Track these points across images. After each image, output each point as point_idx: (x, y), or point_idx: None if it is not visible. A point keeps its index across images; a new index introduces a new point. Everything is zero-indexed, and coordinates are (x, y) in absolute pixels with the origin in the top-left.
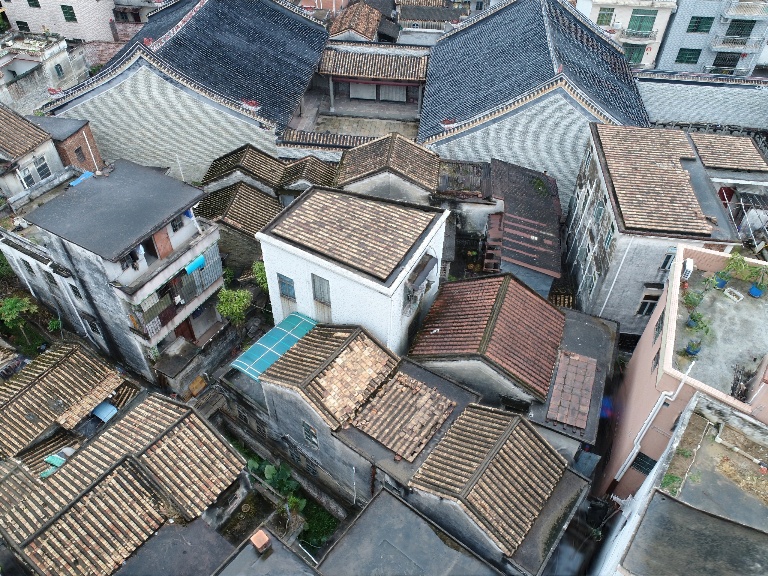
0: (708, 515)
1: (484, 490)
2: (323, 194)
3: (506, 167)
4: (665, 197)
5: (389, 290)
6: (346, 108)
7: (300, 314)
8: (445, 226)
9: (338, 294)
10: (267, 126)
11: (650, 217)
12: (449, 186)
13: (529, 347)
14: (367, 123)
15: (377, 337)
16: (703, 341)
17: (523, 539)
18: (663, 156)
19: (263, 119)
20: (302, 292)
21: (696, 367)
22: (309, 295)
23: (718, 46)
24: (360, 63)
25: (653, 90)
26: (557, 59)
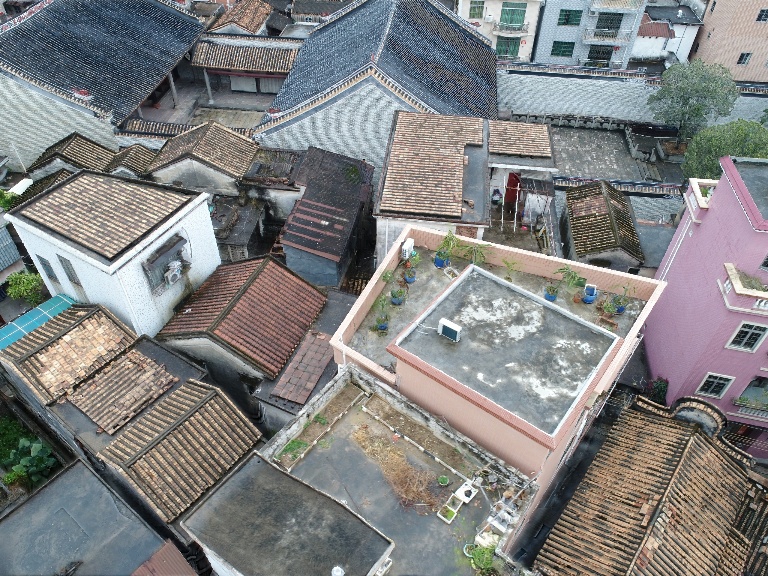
0: (286, 476)
1: (155, 459)
2: (89, 178)
3: (322, 155)
4: (432, 181)
5: (108, 268)
6: (226, 100)
7: (64, 295)
8: (250, 212)
9: (81, 274)
10: (101, 115)
11: (408, 200)
12: (259, 173)
13: (271, 326)
14: (244, 115)
15: (123, 316)
16: (401, 317)
17: (188, 506)
18: (450, 142)
19: (96, 108)
20: (59, 273)
21: (381, 341)
22: (64, 276)
23: (588, 39)
24: (232, 55)
25: (525, 82)
26: (388, 49)
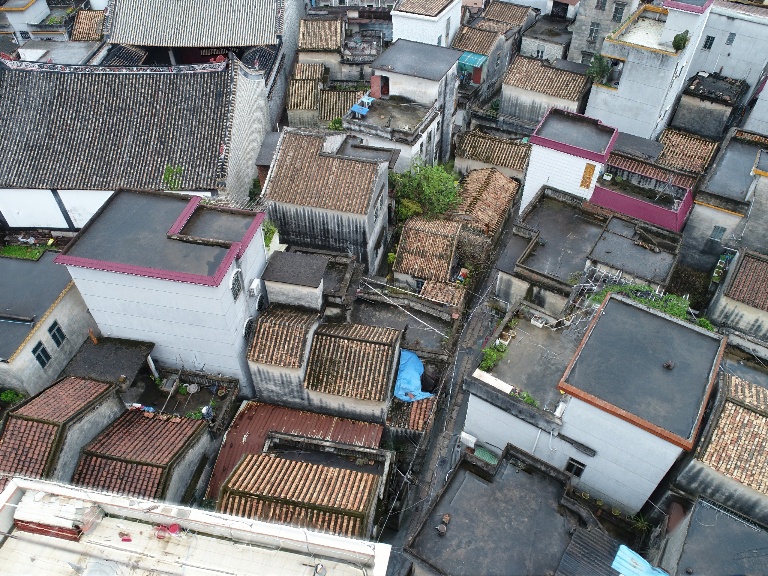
0: None
1: None
2: (400, 8)
3: (315, 9)
4: None
5: None
6: None
7: None
8: (357, 34)
9: None
10: None
11: None
12: None
13: None
14: None
15: None
16: None
17: None
18: None
19: (262, 70)
20: None
21: None
22: None
23: None
24: None
25: None
26: None
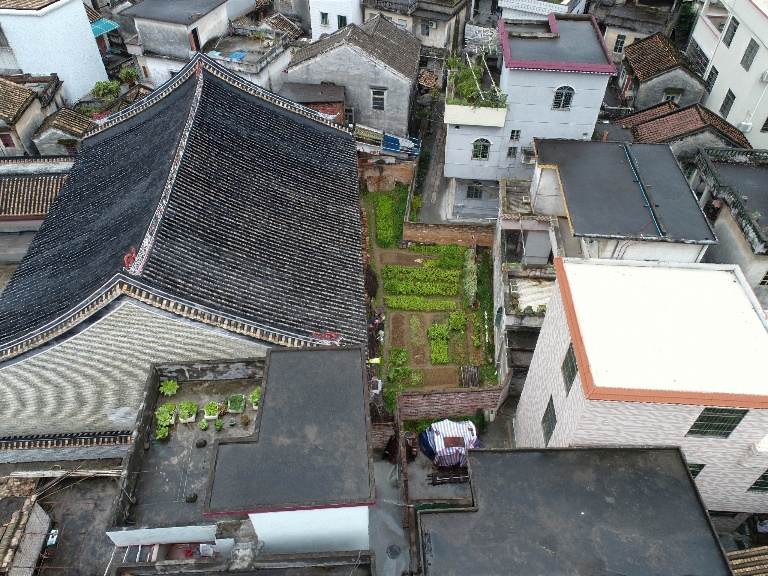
0: None
1: None
2: (33, 7)
3: None
4: None
5: None
6: None
7: None
8: None
9: None
10: None
11: None
12: None
13: None
14: None
15: None
16: None
17: None
18: None
19: None
20: None
21: None
22: None
23: None
24: None
25: None
26: None
